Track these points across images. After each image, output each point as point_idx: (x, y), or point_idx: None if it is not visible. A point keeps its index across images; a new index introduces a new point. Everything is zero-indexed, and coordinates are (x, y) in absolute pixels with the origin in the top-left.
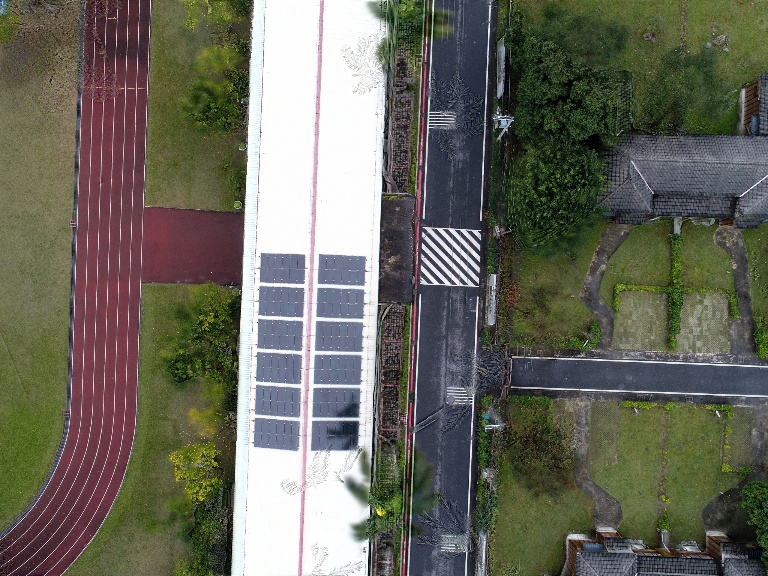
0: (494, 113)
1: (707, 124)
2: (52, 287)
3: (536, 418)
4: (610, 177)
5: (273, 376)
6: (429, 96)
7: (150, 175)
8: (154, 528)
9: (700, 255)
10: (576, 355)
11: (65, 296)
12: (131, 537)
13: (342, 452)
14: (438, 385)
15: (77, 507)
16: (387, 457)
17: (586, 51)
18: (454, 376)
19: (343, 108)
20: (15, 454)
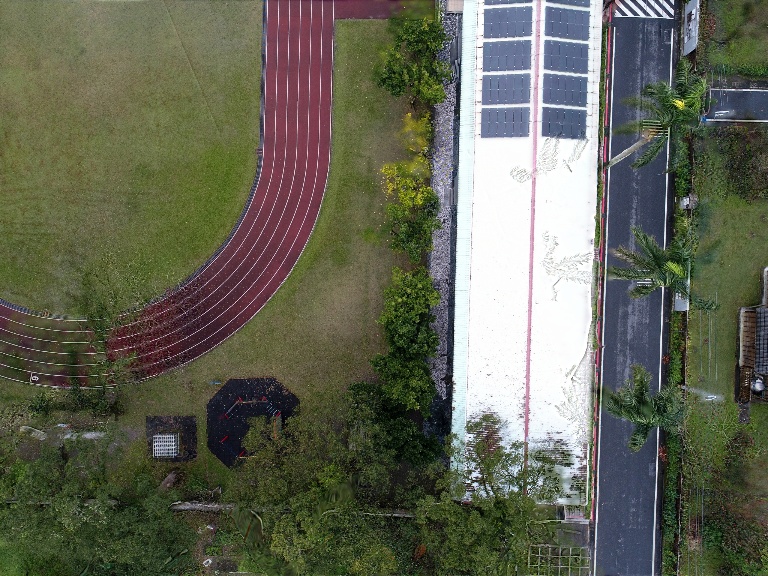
0: None
1: None
2: (244, 24)
3: (732, 151)
4: None
5: (501, 65)
6: None
7: None
8: (349, 266)
9: None
10: None
11: (257, 33)
12: (326, 275)
13: (571, 141)
14: (633, 118)
15: (271, 245)
16: None
17: None
18: (649, 109)
19: None
20: (208, 192)
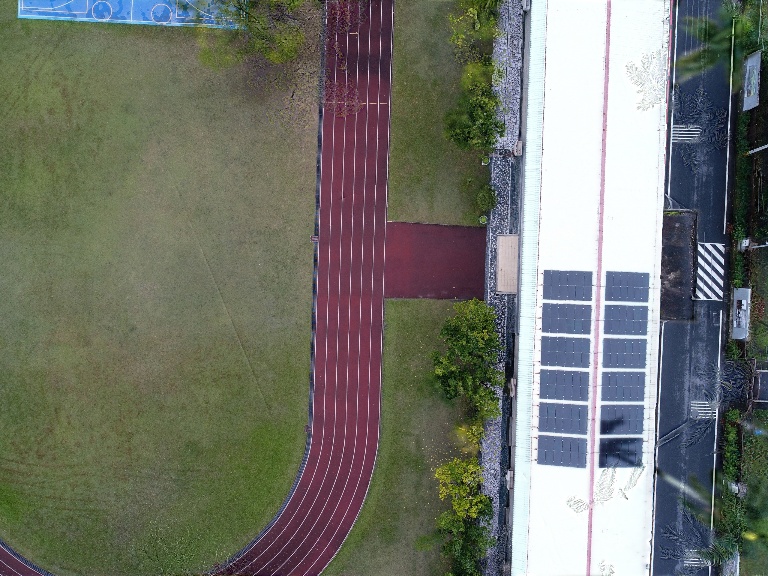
0: (740, 127)
1: None
2: (294, 302)
3: None
4: None
5: (558, 393)
6: (672, 110)
7: (392, 190)
8: (397, 543)
9: None
10: None
11: (307, 311)
12: (374, 552)
13: (627, 469)
14: (682, 399)
15: (320, 523)
16: None
17: None
18: (698, 390)
19: (628, 124)
20: (257, 470)
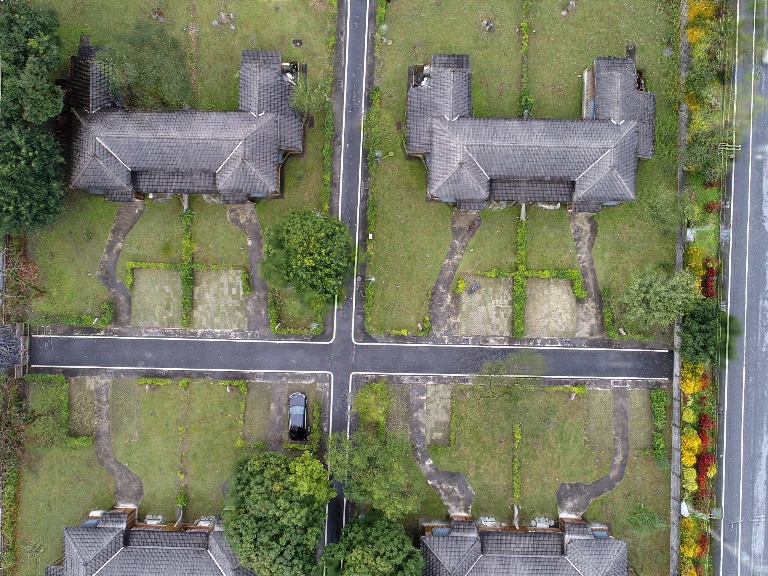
0: None
1: (218, 102)
2: None
3: (57, 396)
4: (81, 154)
5: None
6: None
7: None
8: None
9: (214, 232)
10: (95, 333)
11: None
12: None
13: None
14: None
15: None
16: None
17: (97, 31)
18: None
19: None
20: None
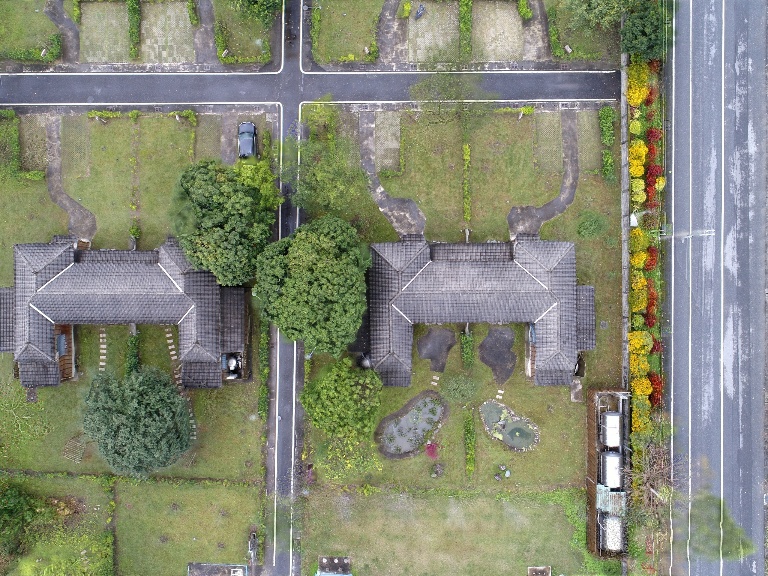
0: None
1: None
2: None
3: (8, 134)
4: None
5: None
6: None
7: None
8: None
9: None
10: (44, 70)
11: None
12: None
13: None
14: None
15: None
16: None
17: None
18: None
19: None
20: None
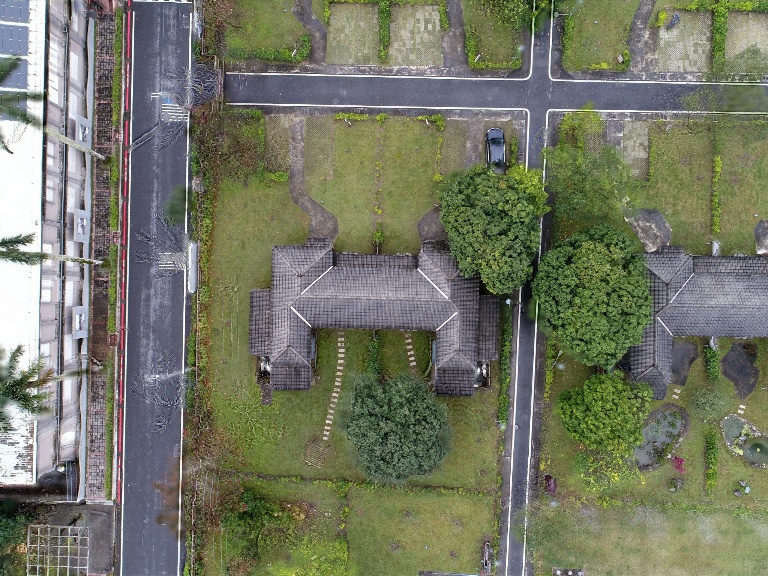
0: None
1: None
2: None
3: (251, 134)
4: None
5: None
6: None
7: None
8: None
9: None
10: (290, 70)
11: None
12: None
13: (9, 122)
14: (153, 102)
15: None
16: (102, 174)
17: None
18: (169, 93)
19: None
20: None
